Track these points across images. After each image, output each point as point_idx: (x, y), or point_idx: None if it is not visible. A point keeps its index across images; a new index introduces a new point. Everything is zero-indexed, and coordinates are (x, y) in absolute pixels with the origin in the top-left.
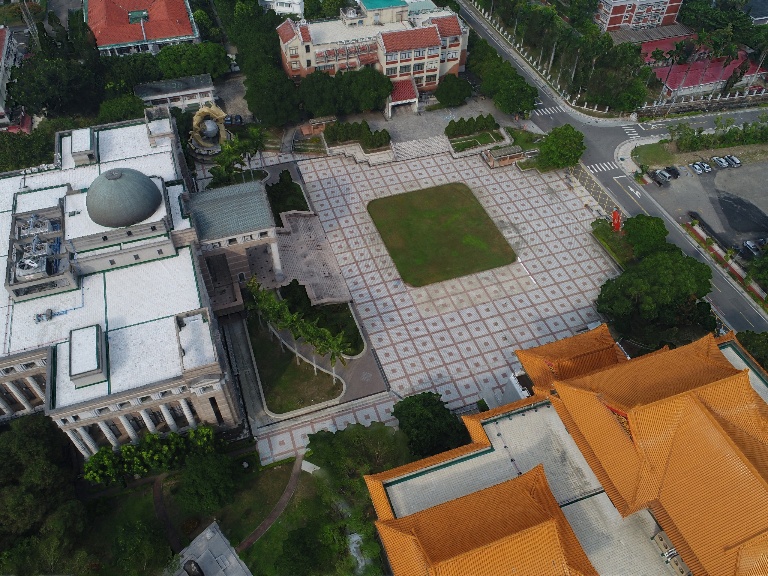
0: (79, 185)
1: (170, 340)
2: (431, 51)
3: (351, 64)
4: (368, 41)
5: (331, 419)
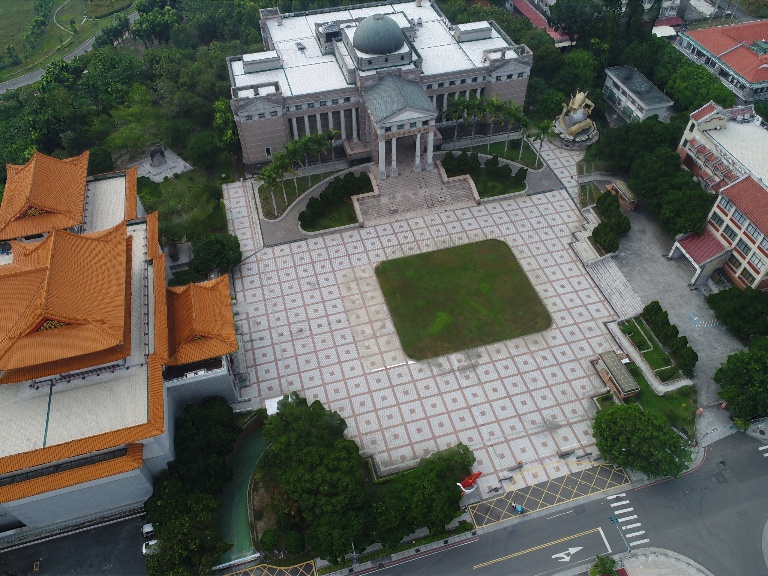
0: (430, 39)
1: (269, 90)
2: (767, 244)
3: (712, 181)
4: (743, 175)
5: (248, 215)
